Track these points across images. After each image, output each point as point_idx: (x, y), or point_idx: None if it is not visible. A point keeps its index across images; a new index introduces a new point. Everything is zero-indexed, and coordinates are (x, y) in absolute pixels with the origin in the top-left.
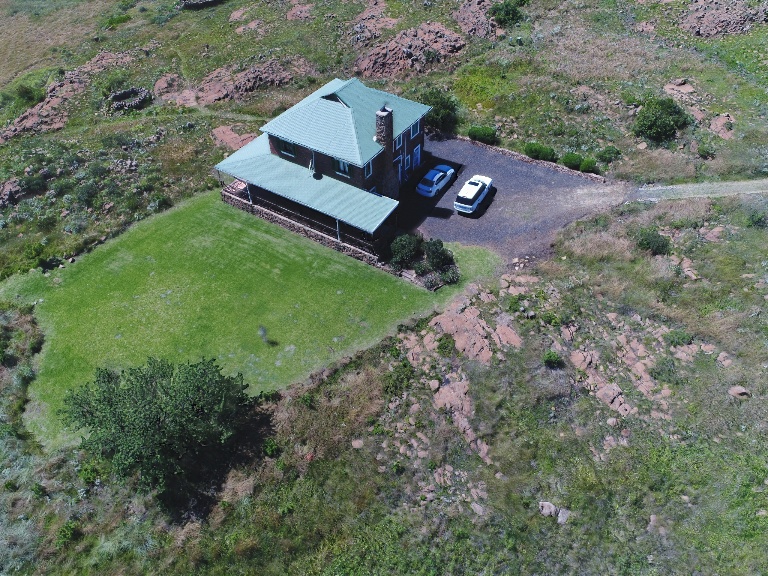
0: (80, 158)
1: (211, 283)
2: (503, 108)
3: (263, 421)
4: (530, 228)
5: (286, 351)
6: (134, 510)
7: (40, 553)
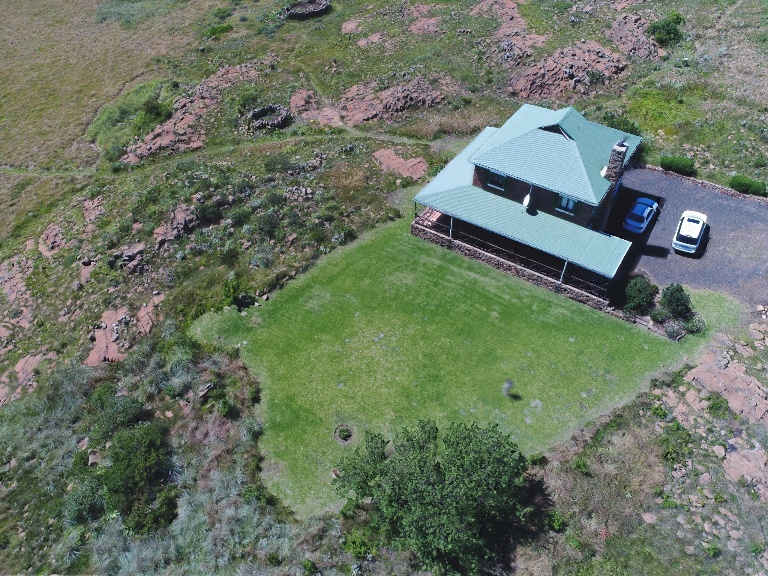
0: (250, 184)
1: (426, 326)
2: (691, 136)
3: (536, 489)
4: (763, 271)
5: (533, 406)
6: None
7: None
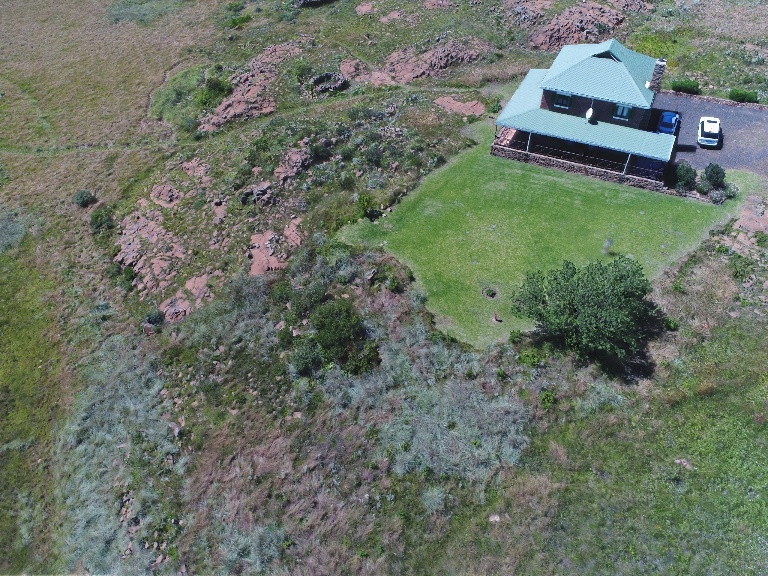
0: (346, 128)
1: (527, 216)
2: (690, 65)
3: (649, 307)
4: None
5: None
6: (584, 380)
7: (535, 415)
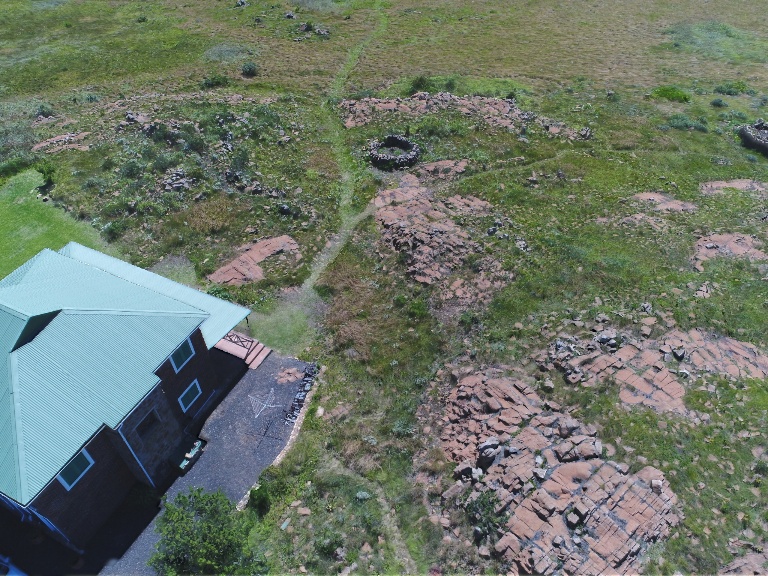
0: (199, 146)
1: None
2: None
3: None
4: None
5: None
6: None
7: None
